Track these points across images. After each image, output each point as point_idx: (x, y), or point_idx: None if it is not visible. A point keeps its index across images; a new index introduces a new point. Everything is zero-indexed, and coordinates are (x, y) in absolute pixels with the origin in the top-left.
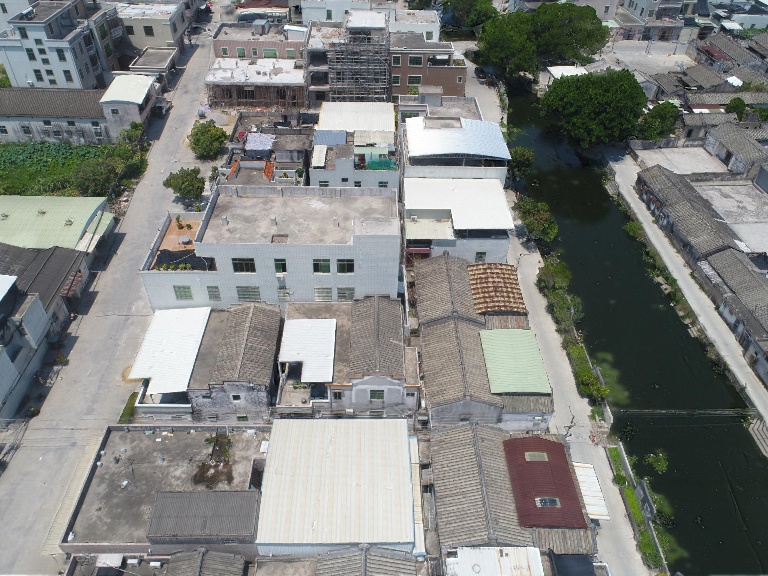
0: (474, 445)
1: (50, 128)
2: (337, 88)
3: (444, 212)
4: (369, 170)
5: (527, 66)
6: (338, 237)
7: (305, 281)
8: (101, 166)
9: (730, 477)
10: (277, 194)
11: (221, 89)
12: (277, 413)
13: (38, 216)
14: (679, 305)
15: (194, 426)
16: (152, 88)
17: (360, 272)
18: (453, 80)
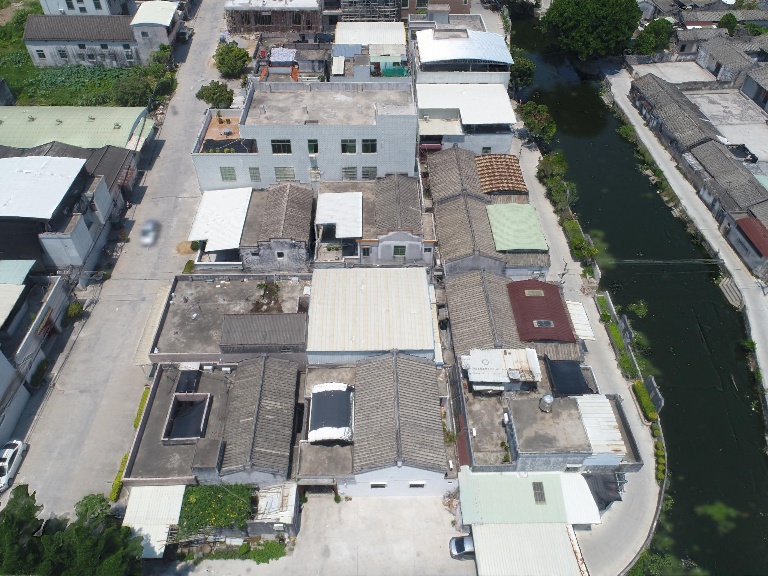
0: (482, 285)
1: (85, 52)
2: (349, 12)
3: (453, 112)
4: (384, 77)
5: None
6: (362, 122)
7: (334, 161)
8: (137, 82)
9: (700, 320)
10: (306, 90)
11: (240, 15)
12: None
13: (89, 121)
14: (664, 192)
15: (247, 275)
16: (176, 13)
17: (382, 152)
18: (459, 2)
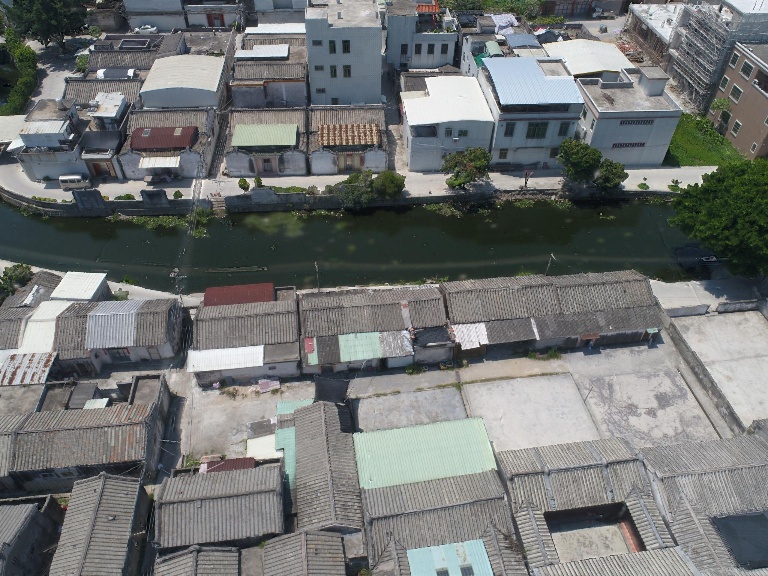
0: None
1: None
2: None
3: None
4: (473, 58)
5: None
6: None
7: None
8: None
9: None
10: None
11: None
12: None
13: None
14: None
15: None
16: None
17: None
18: (763, 116)
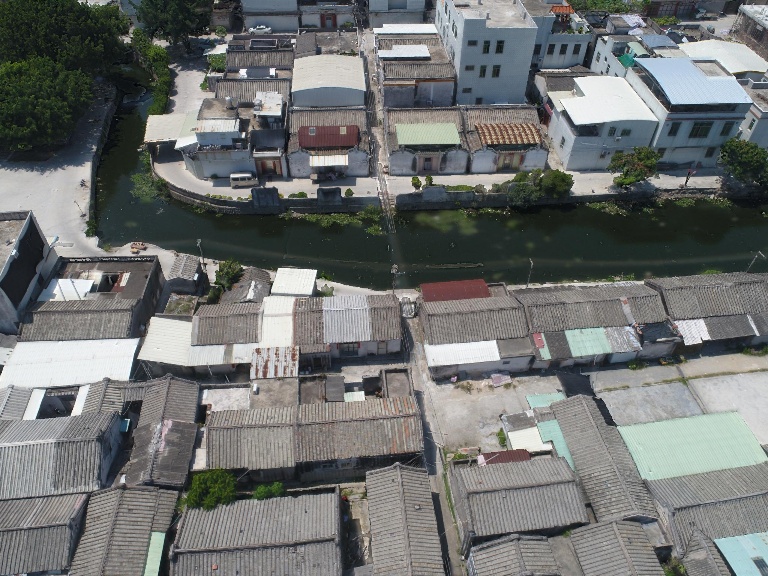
0: None
1: None
2: None
3: None
4: (616, 58)
5: None
6: None
7: None
8: None
9: None
10: None
11: None
12: None
13: None
14: None
15: None
16: None
17: None
18: None
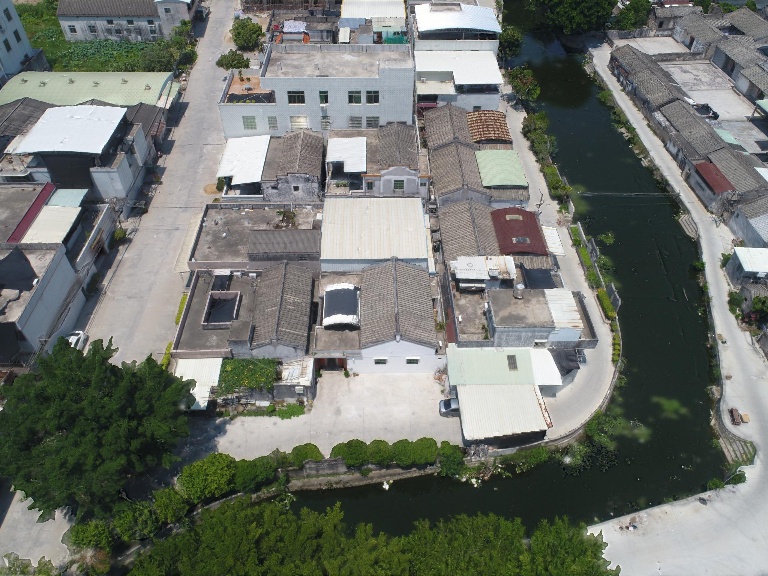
0: (470, 211)
1: (112, 27)
2: None
3: (447, 74)
4: None
5: None
6: (366, 76)
7: (342, 111)
8: (163, 52)
9: (660, 247)
10: (317, 51)
11: None
12: None
13: (122, 83)
14: (636, 146)
15: (268, 204)
16: None
17: (384, 102)
18: None
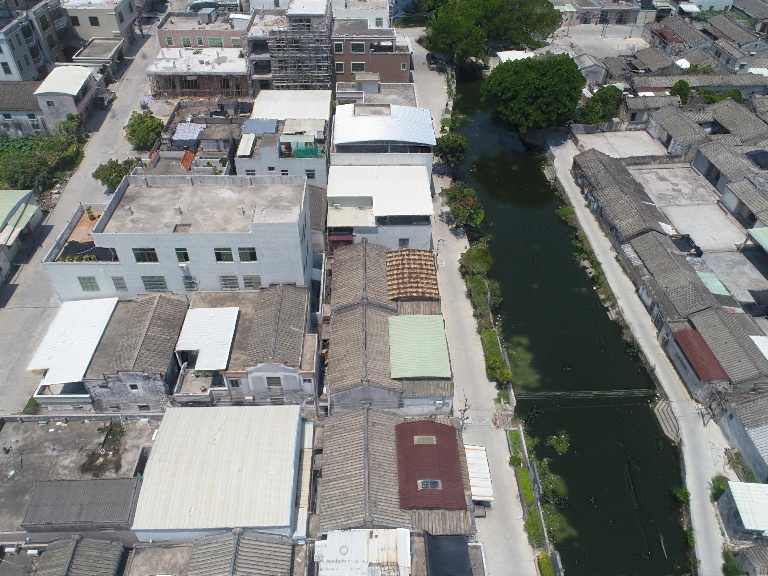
0: (364, 430)
1: None
2: (280, 76)
3: (367, 199)
4: (295, 158)
5: (474, 51)
6: (241, 225)
7: (209, 270)
8: (32, 158)
9: (629, 457)
10: (187, 183)
11: (164, 79)
12: (176, 402)
13: None
14: (601, 288)
15: (87, 416)
16: (91, 79)
17: (263, 260)
18: (397, 67)
